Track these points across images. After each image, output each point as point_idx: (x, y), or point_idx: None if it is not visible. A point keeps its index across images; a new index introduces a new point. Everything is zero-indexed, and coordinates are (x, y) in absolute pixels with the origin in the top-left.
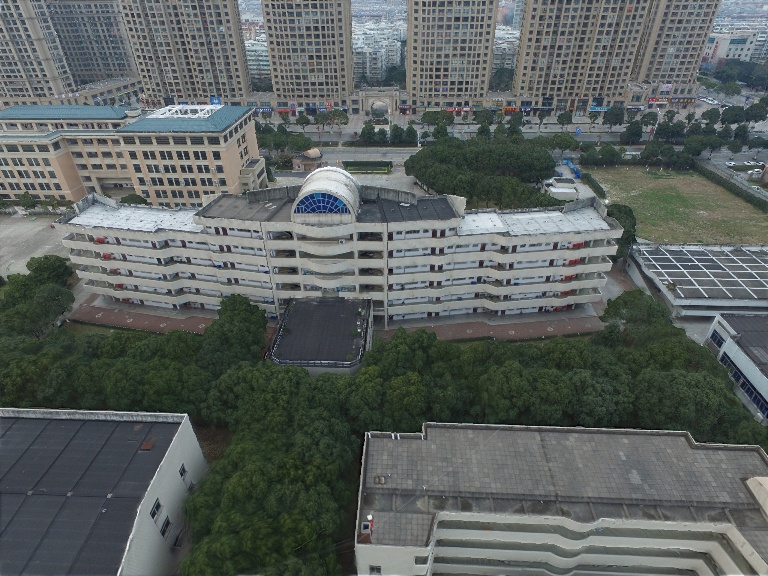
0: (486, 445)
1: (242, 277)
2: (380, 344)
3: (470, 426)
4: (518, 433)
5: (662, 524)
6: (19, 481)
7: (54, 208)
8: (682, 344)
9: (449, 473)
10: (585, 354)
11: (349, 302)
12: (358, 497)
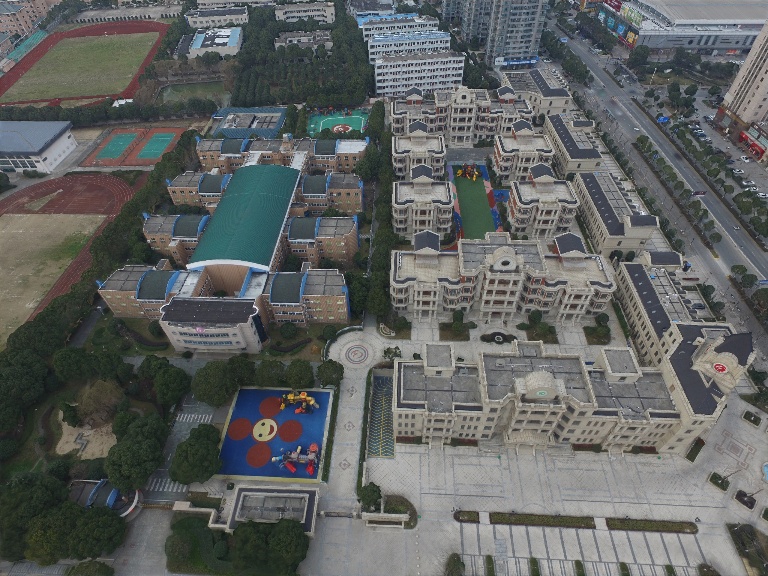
0: (294, 5)
1: (244, 1)
2: (277, 3)
3: (291, 4)
4: (299, 4)
5: (314, 7)
6: (226, 12)
7: (164, 2)
8: (336, 0)
9: (288, 7)
10: (315, 0)
11: (271, 6)
12: (275, 9)
